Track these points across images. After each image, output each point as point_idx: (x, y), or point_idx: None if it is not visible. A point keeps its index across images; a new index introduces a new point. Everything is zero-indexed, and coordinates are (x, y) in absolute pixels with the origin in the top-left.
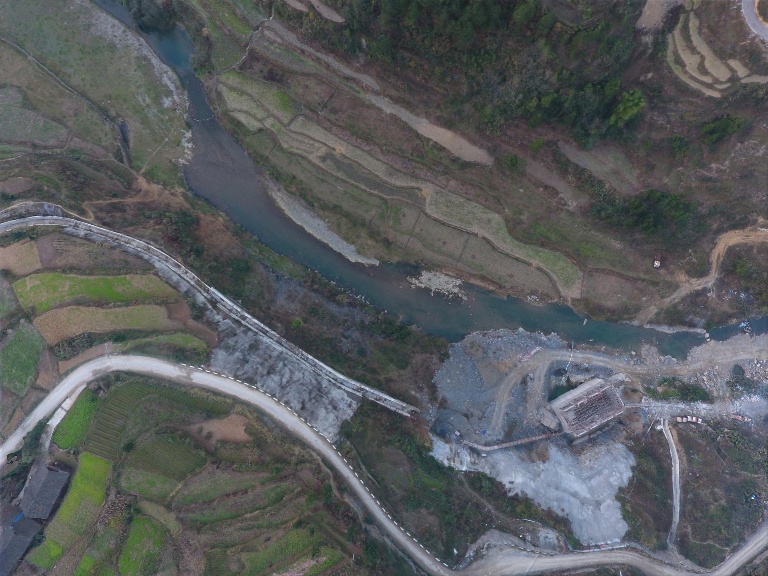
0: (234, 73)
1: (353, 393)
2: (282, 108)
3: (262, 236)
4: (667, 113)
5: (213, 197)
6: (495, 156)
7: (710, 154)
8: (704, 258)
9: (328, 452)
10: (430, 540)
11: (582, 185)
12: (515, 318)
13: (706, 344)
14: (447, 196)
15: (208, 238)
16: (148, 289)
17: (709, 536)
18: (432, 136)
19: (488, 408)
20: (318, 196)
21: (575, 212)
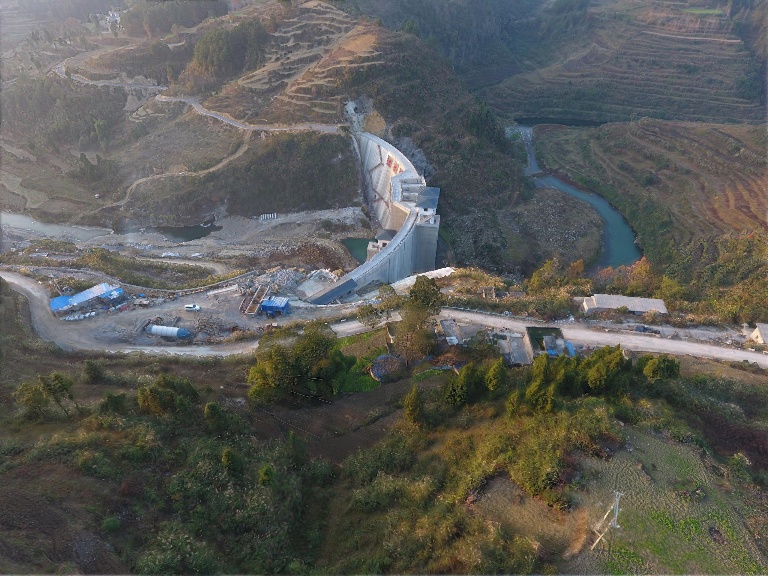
0: None
1: None
2: None
3: None
4: None
5: None
6: None
7: None
8: (122, 190)
9: None
10: None
11: None
12: None
13: None
14: None
15: None
16: None
17: None
18: (12, 151)
19: None
20: None
21: (65, 176)
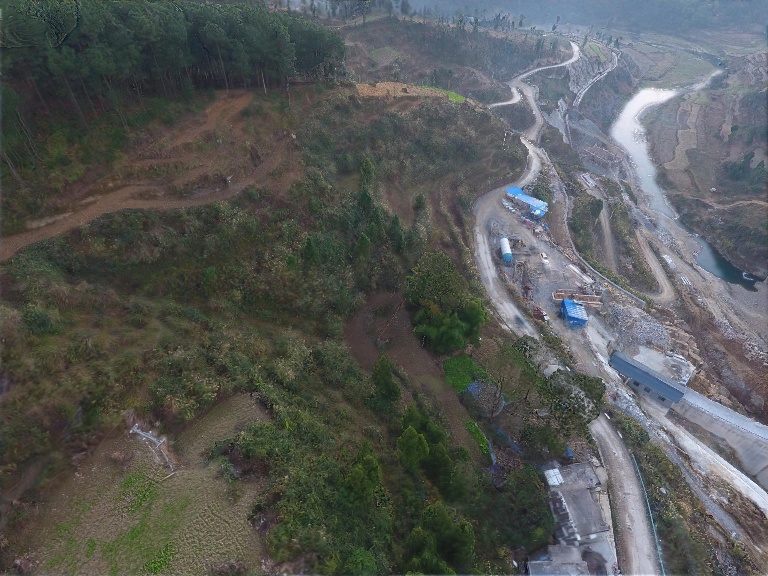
0: None
1: None
2: None
3: None
4: None
5: None
6: None
7: None
8: None
9: None
10: None
11: None
12: None
13: None
14: None
15: (624, 85)
16: (601, 58)
17: None
18: (724, 127)
19: (585, 128)
20: (663, 109)
21: (721, 163)
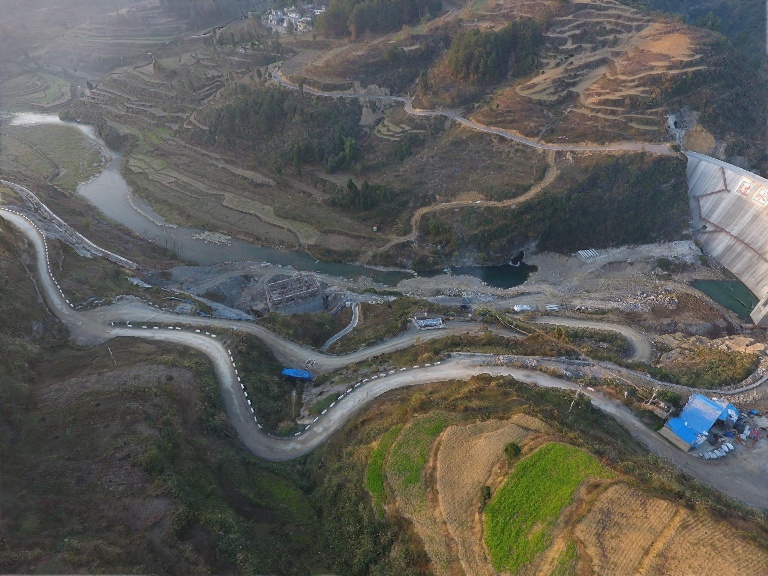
0: (142, 154)
1: (96, 254)
2: (160, 165)
3: (106, 212)
4: (376, 153)
5: (89, 196)
6: (276, 180)
7: (399, 166)
8: (405, 222)
9: (37, 241)
10: (72, 288)
11: (325, 188)
12: (263, 257)
13: (414, 278)
14: (240, 198)
15: (67, 201)
16: None
17: (352, 341)
18: (241, 174)
19: (203, 280)
20: (156, 196)
21: (321, 204)
